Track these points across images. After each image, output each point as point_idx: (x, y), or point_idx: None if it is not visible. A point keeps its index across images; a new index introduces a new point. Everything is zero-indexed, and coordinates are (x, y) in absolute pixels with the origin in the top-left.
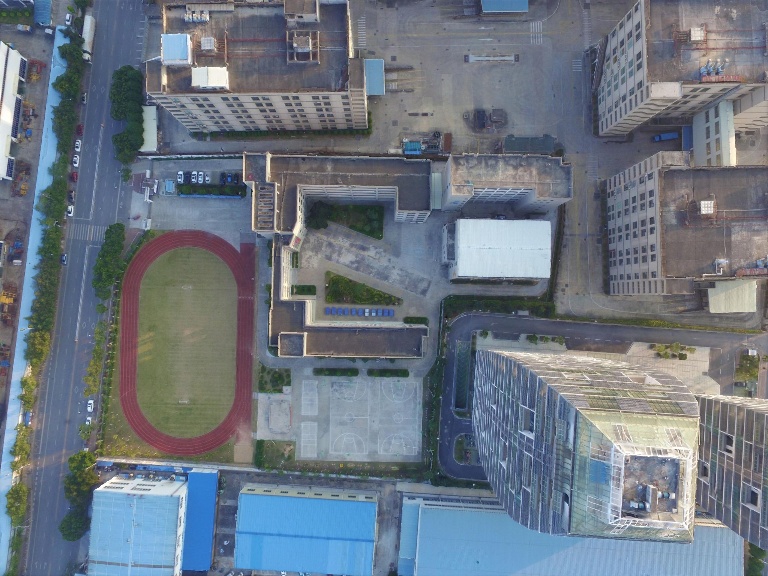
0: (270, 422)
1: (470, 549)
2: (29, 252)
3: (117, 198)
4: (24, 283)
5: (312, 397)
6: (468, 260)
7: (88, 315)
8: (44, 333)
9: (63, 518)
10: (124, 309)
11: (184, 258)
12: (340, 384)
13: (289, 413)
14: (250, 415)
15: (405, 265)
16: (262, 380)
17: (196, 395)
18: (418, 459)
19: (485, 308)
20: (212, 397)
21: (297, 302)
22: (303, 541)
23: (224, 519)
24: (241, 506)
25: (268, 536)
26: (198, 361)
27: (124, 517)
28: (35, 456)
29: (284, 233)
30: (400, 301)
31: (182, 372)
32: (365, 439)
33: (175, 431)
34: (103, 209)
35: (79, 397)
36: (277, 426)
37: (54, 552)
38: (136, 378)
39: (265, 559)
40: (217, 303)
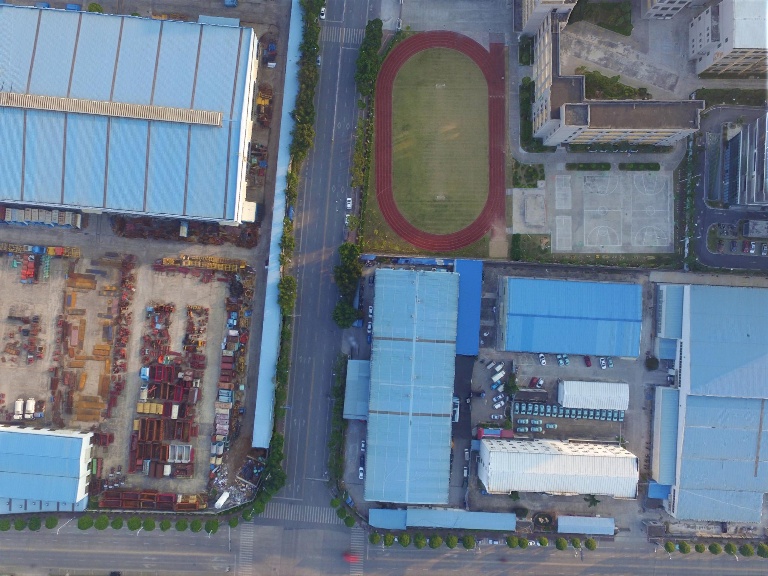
0: (526, 216)
1: (740, 323)
2: (289, 50)
3: (367, 0)
4: (285, 80)
5: (565, 191)
6: (744, 32)
7: (343, 115)
8: (310, 126)
9: (335, 306)
10: (378, 109)
11: (435, 58)
12: (592, 178)
13: (544, 207)
14: (504, 211)
15: (653, 61)
16: (516, 175)
17: (451, 192)
18: (671, 250)
19: (736, 99)
20: (466, 194)
21: (575, 77)
22: (572, 322)
23: (483, 311)
24: (510, 290)
25: (538, 318)
26: (452, 159)
27: (407, 294)
28: (296, 254)
29: (564, 8)
30: (649, 96)
31: (436, 170)
32: (618, 231)
33: (431, 228)
34: (354, 12)
35: (337, 196)
36: (533, 219)
37: (317, 347)
38: (391, 177)
39: (535, 341)
40: (469, 102)
